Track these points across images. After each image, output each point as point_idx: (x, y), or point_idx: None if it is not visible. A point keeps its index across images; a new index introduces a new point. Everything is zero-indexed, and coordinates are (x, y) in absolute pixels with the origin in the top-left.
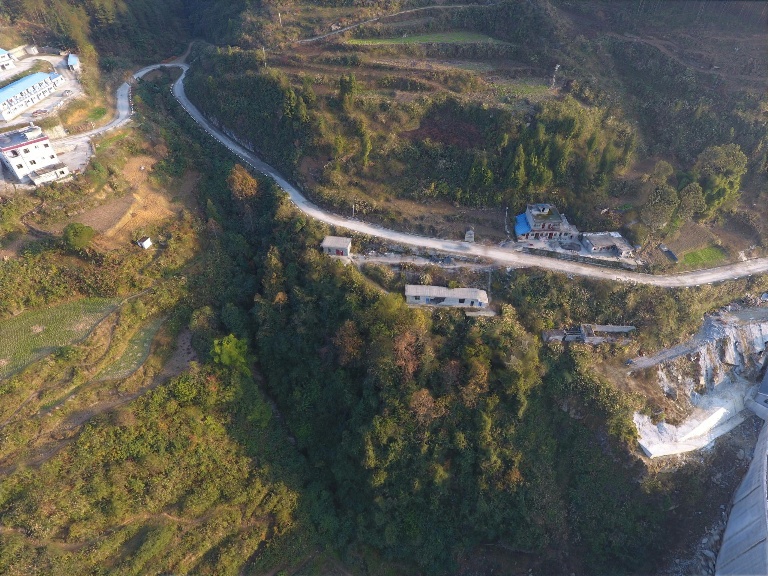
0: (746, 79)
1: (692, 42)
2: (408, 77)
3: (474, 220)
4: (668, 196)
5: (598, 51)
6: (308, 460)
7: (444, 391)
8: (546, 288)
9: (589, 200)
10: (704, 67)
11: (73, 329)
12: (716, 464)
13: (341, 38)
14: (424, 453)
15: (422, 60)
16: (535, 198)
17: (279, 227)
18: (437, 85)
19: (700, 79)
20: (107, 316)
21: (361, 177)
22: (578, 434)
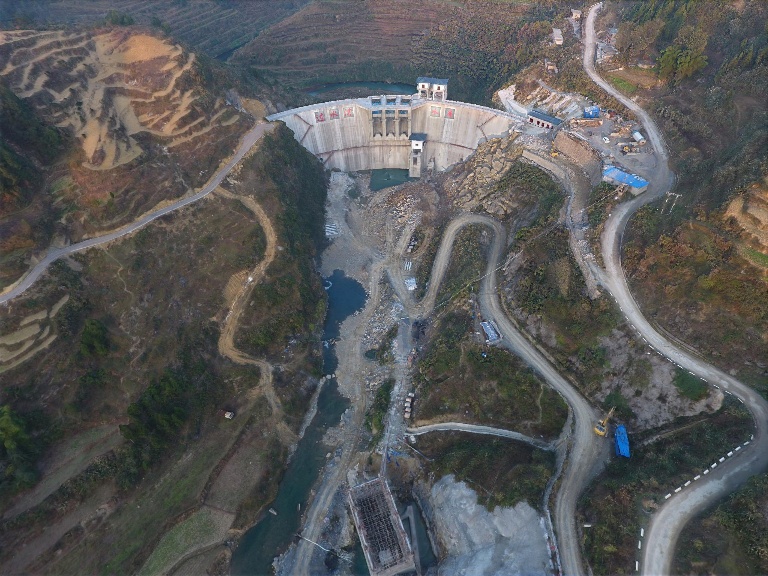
0: None
1: None
2: None
3: None
4: None
5: None
6: None
7: None
8: None
9: None
10: None
11: (522, 4)
12: None
13: None
14: None
15: None
16: None
17: None
18: None
19: None
20: (530, 6)
21: None
22: None
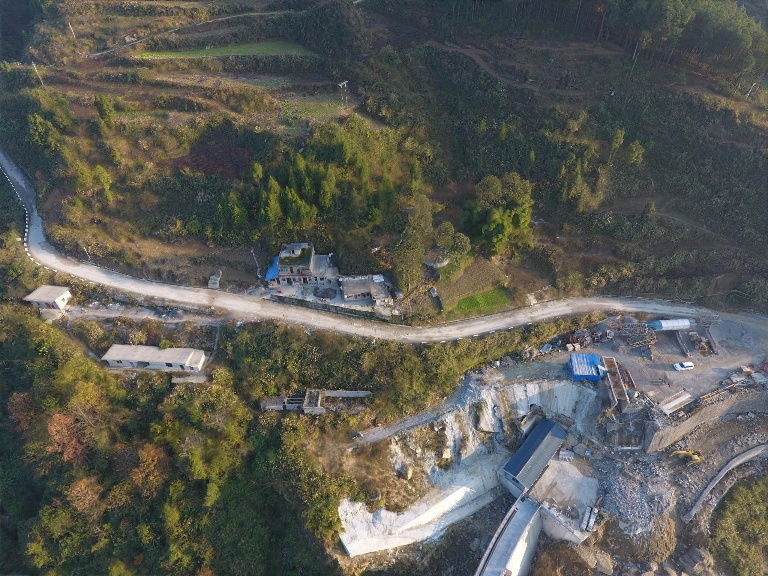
0: (559, 94)
1: (506, 52)
2: (185, 96)
3: (225, 262)
4: (407, 240)
5: (409, 63)
6: (18, 544)
7: (122, 477)
8: (273, 347)
9: (360, 237)
10: (519, 80)
11: None
12: (449, 555)
13: (132, 51)
14: (105, 548)
15: (215, 75)
16: (300, 235)
17: (1, 274)
18: (218, 105)
19: (513, 94)
20: None
21: (106, 213)
22: (288, 522)
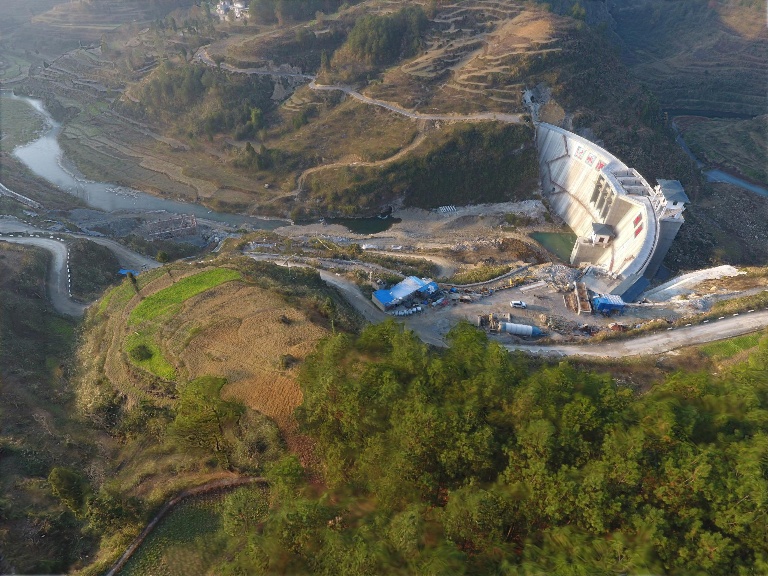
0: None
1: None
2: None
3: None
4: None
5: None
6: None
7: None
8: None
9: None
10: None
11: None
12: None
13: None
14: None
15: None
16: None
17: None
18: None
19: None
20: None
21: None
22: None
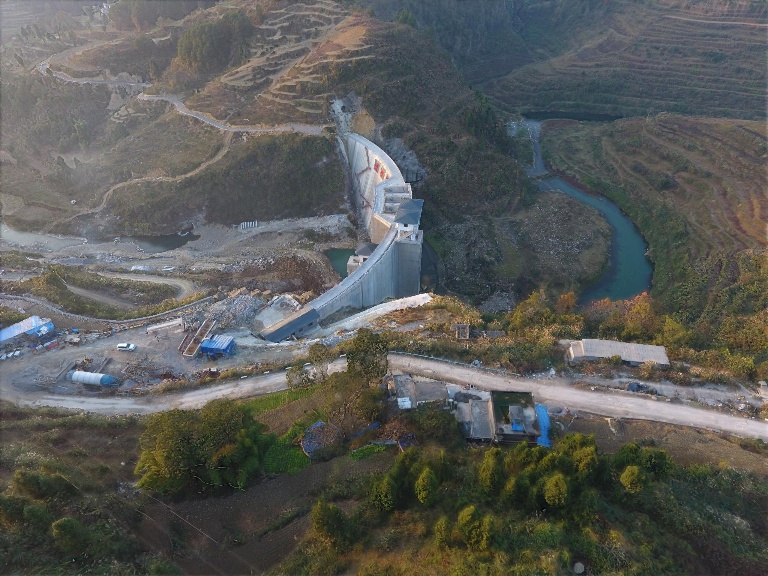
0: None
1: None
2: None
3: None
4: (372, 334)
5: None
6: None
7: None
8: None
9: None
10: None
11: None
12: None
13: None
14: None
15: None
16: None
17: None
18: None
19: None
20: None
21: None
22: None
